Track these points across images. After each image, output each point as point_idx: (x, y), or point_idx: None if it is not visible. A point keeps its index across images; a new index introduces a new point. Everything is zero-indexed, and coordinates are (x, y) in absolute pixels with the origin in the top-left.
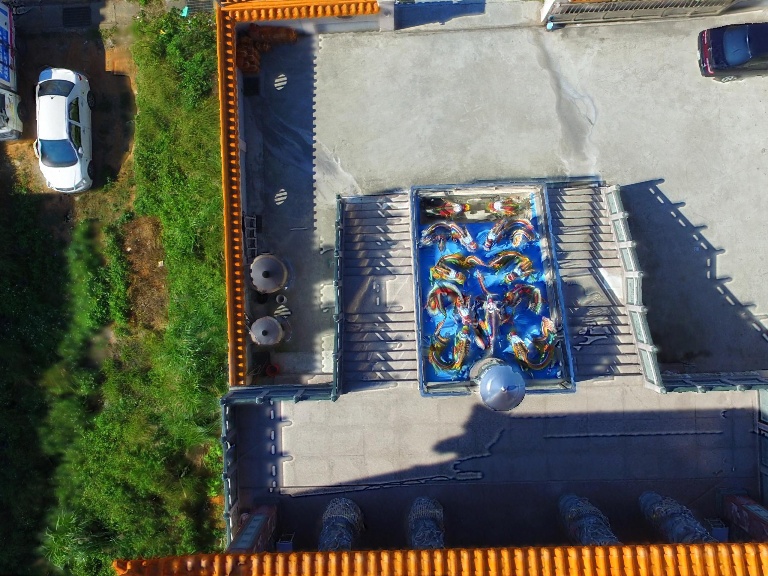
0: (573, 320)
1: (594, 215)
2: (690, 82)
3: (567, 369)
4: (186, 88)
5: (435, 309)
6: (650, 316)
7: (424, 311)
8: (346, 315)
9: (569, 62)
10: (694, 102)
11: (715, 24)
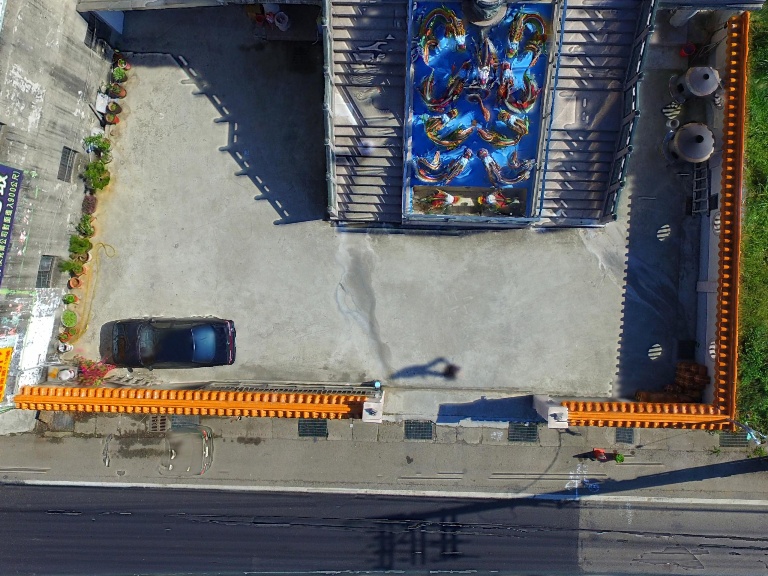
0: (389, 71)
1: (350, 188)
2: (244, 319)
3: (406, 13)
4: (762, 349)
5: (533, 85)
6: (296, 89)
7: (542, 86)
8: (622, 89)
9: (360, 348)
10: (241, 299)
11: (216, 374)
